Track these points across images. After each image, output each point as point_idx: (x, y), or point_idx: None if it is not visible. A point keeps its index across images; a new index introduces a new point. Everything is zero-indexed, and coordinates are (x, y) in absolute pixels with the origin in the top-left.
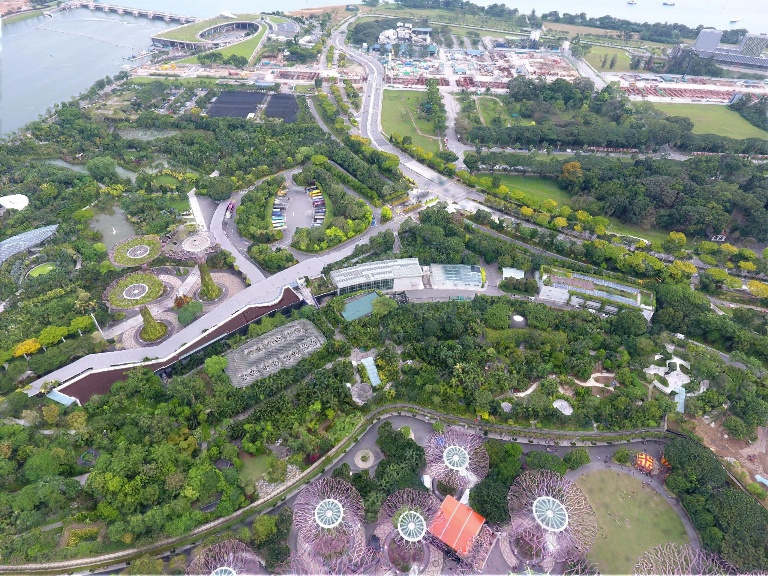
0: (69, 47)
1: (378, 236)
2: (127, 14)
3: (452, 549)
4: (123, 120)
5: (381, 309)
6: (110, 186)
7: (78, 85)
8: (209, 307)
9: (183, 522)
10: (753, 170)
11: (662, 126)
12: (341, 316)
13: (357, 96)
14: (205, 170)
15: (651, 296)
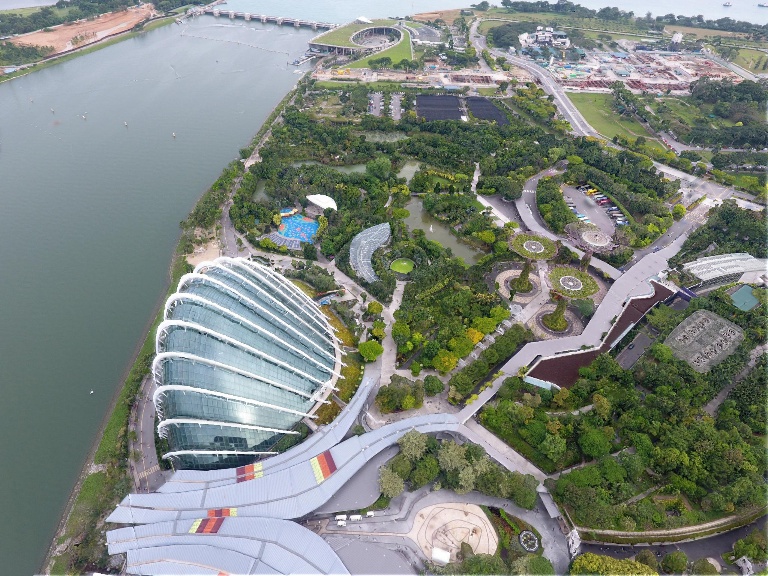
0: (227, 53)
1: (697, 232)
2: (253, 20)
3: None
4: (346, 123)
5: None
6: (395, 186)
7: (267, 90)
8: None
9: (760, 493)
10: None
11: None
12: None
13: (553, 98)
14: (463, 171)
15: None
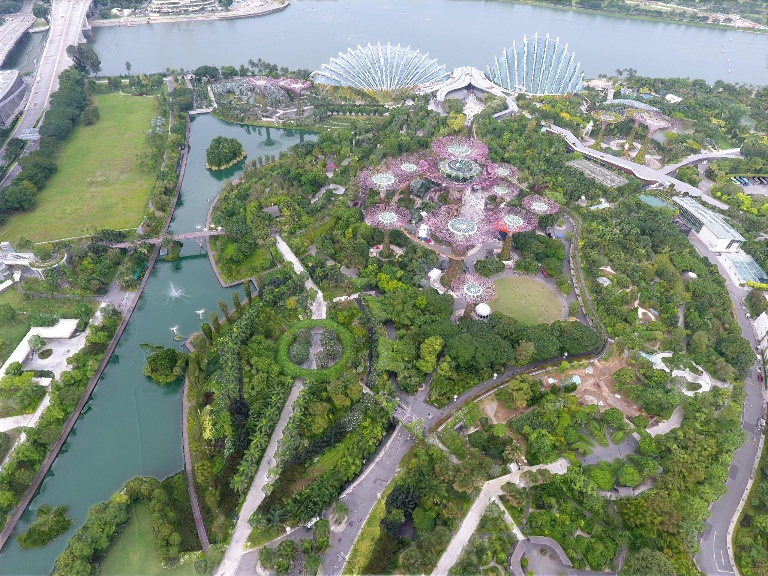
0: None
1: (759, 219)
2: None
3: None
4: None
5: None
6: None
7: None
8: None
9: None
10: None
11: None
12: (641, 195)
13: None
14: None
15: None
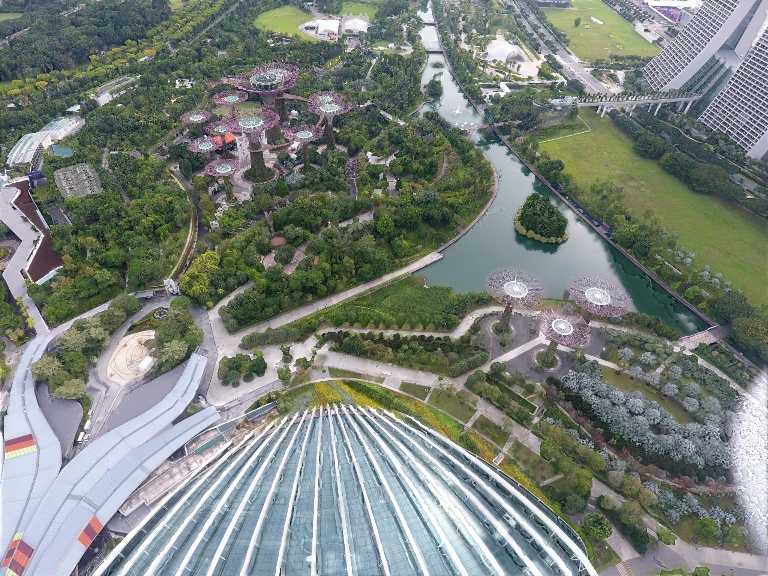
0: None
1: None
2: None
3: (232, 141)
4: None
5: (73, 141)
6: None
7: None
8: None
9: (185, 203)
10: (66, 17)
11: None
12: None
13: None
14: None
15: (132, 75)
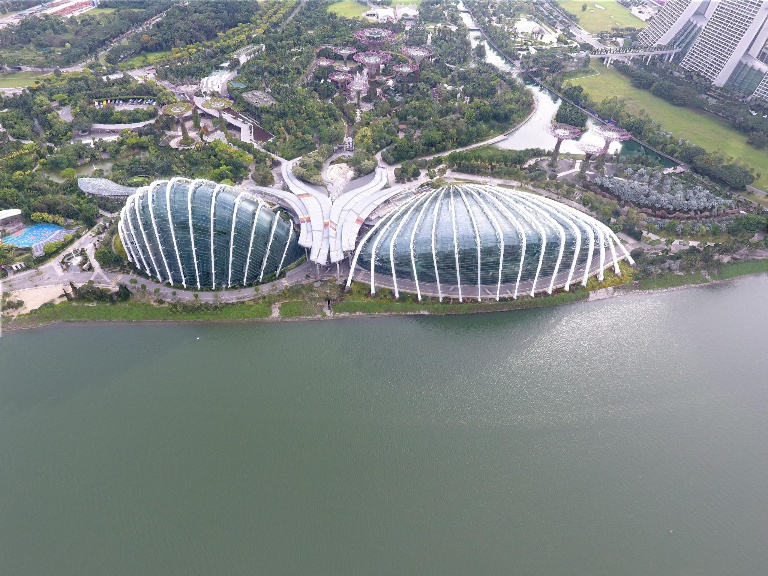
0: None
1: None
2: None
3: None
4: None
5: (243, 79)
6: None
7: None
8: (211, 126)
9: None
10: None
11: (127, 12)
12: None
13: None
14: None
15: None
